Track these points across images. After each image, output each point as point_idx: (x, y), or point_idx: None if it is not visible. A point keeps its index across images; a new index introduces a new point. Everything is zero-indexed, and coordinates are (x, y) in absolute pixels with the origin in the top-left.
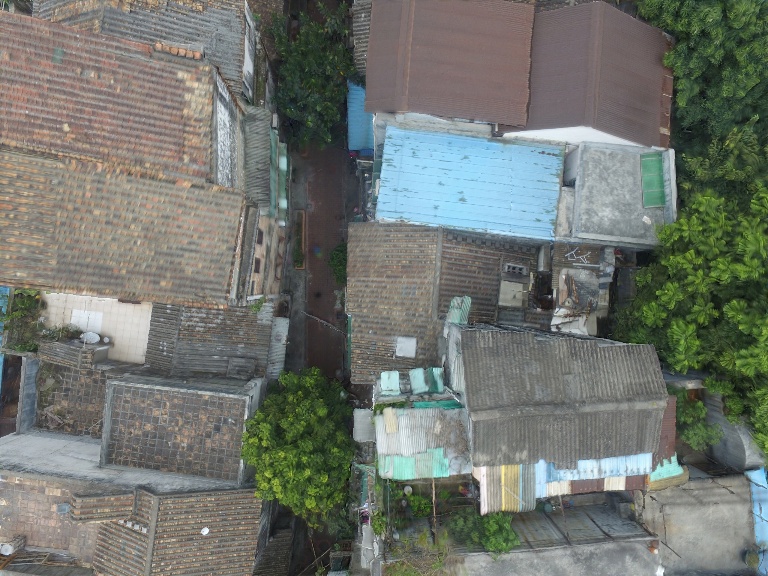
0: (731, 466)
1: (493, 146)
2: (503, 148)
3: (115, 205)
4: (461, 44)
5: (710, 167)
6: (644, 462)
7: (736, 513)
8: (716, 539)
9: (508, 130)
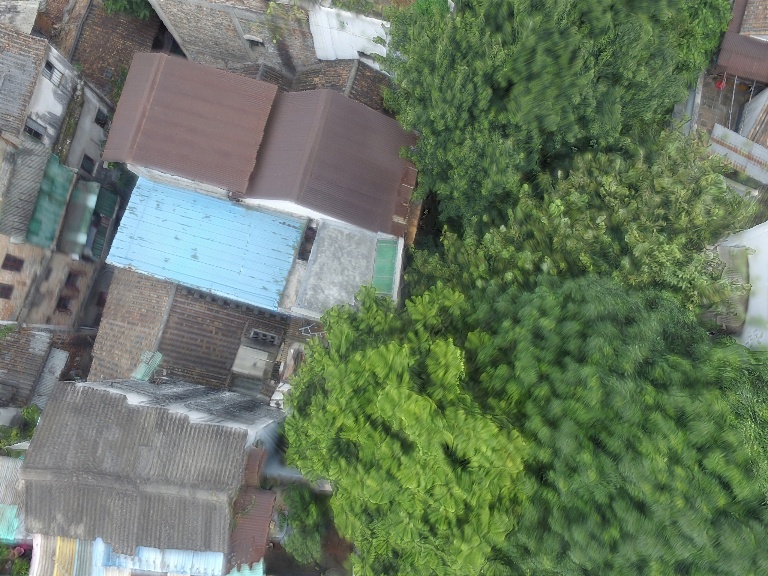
0: None
1: (236, 210)
2: (245, 213)
3: None
4: (197, 110)
5: None
6: (213, 562)
7: None
8: None
9: (239, 196)
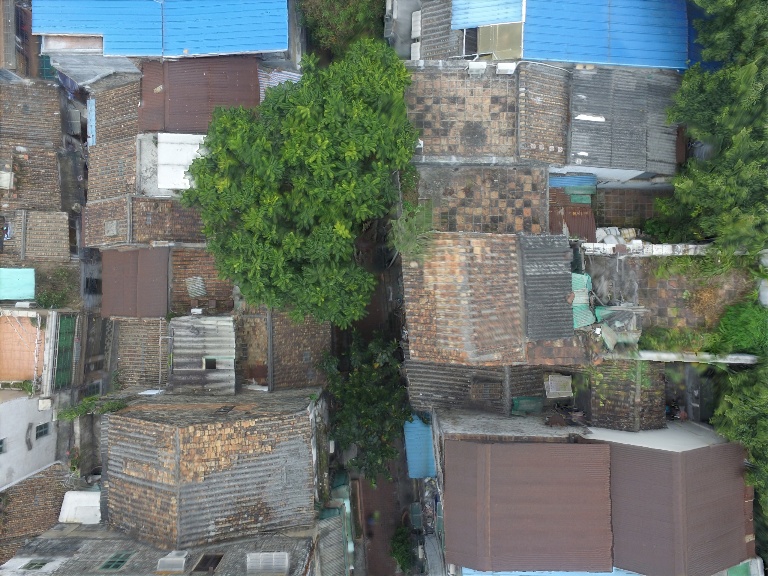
0: None
1: None
2: None
3: None
4: (540, 497)
5: None
6: None
7: None
8: None
9: None
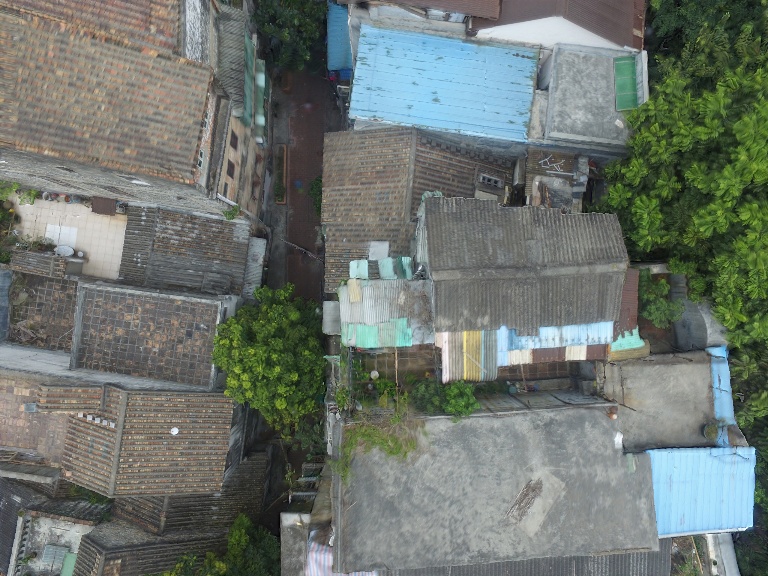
0: (692, 343)
1: (467, 47)
2: (477, 49)
3: (79, 68)
4: None
5: (682, 70)
6: (605, 331)
7: (696, 388)
8: (676, 413)
9: (481, 26)
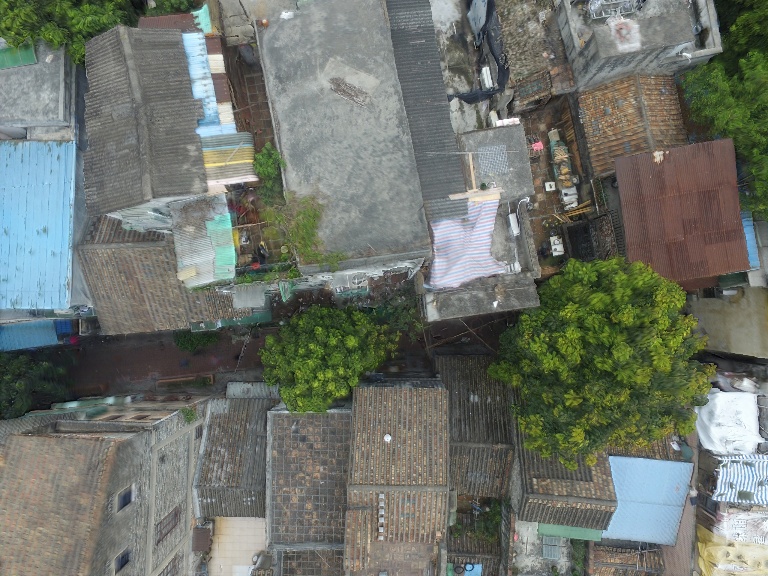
0: None
1: None
2: None
3: (2, 555)
4: None
5: None
6: (193, 40)
7: None
8: None
9: None
